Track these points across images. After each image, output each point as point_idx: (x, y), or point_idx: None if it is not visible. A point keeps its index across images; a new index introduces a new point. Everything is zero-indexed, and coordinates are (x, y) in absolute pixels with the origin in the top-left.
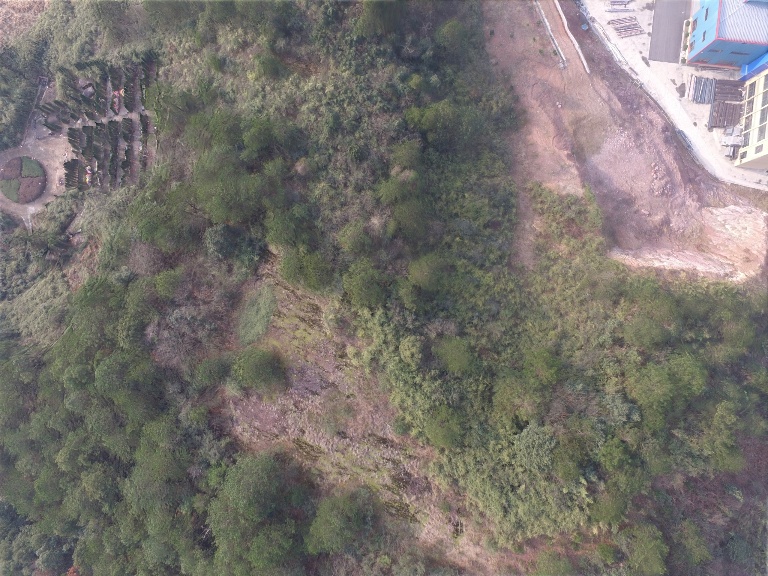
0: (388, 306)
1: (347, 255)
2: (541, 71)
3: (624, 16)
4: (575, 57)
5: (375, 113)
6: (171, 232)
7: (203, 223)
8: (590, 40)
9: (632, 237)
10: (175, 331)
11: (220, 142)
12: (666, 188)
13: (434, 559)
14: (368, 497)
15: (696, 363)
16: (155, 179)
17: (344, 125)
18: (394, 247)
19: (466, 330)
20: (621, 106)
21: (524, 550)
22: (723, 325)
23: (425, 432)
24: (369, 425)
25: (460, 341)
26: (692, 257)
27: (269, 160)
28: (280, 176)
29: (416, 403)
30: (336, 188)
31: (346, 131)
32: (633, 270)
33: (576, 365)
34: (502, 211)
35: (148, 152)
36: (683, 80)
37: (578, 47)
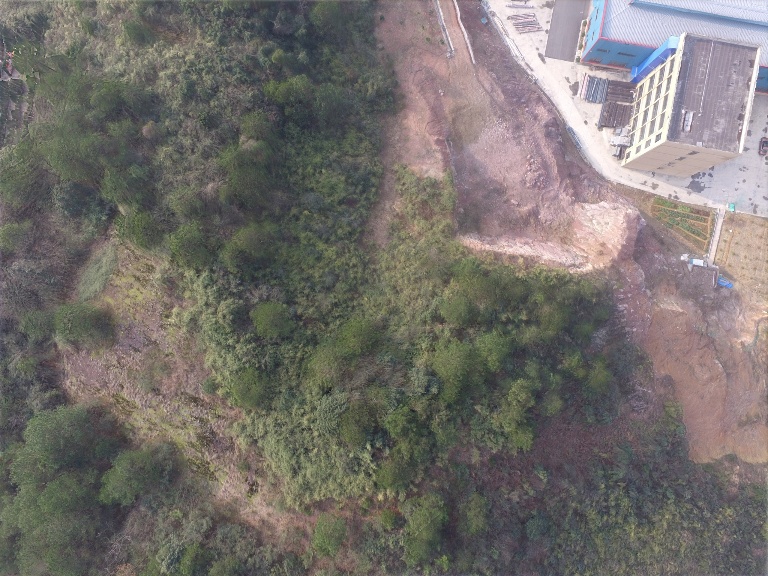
0: (213, 269)
1: (178, 217)
2: (427, 59)
3: (524, 12)
4: (463, 47)
5: (233, 84)
6: (24, 187)
7: (54, 180)
8: (488, 33)
9: (495, 225)
10: (12, 283)
11: (71, 100)
12: (539, 180)
13: (224, 516)
14: (171, 453)
15: (501, 341)
16: (25, 137)
17: (198, 93)
18: (228, 213)
19: (297, 299)
20: (504, 98)
21: (311, 512)
22: (538, 308)
23: (233, 393)
24: (183, 383)
25: (286, 309)
26: (551, 248)
27: (116, 121)
28: (125, 137)
29: (226, 364)
30: (183, 153)
31: (200, 99)
32: (474, 253)
33: (394, 338)
34: (360, 189)
35: (34, 113)
36: (577, 79)
37: (467, 38)
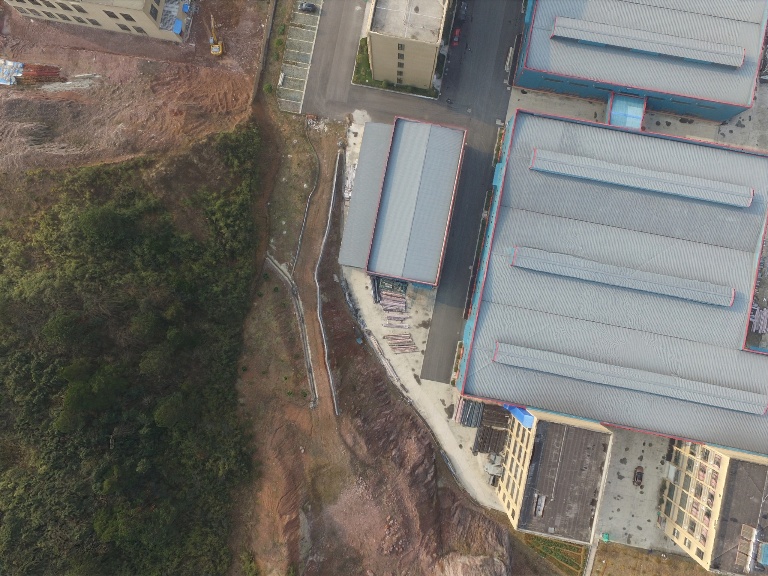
0: None
1: None
2: (290, 411)
3: (400, 332)
4: (327, 396)
5: (62, 518)
6: None
7: None
8: (362, 356)
9: None
10: None
11: None
12: (397, 545)
13: None
14: None
15: None
16: None
17: None
18: None
19: None
20: (366, 451)
21: None
22: None
23: None
24: None
25: None
26: None
27: None
28: None
29: None
30: None
31: (25, 544)
32: None
33: None
34: None
35: None
36: (452, 401)
37: (332, 385)
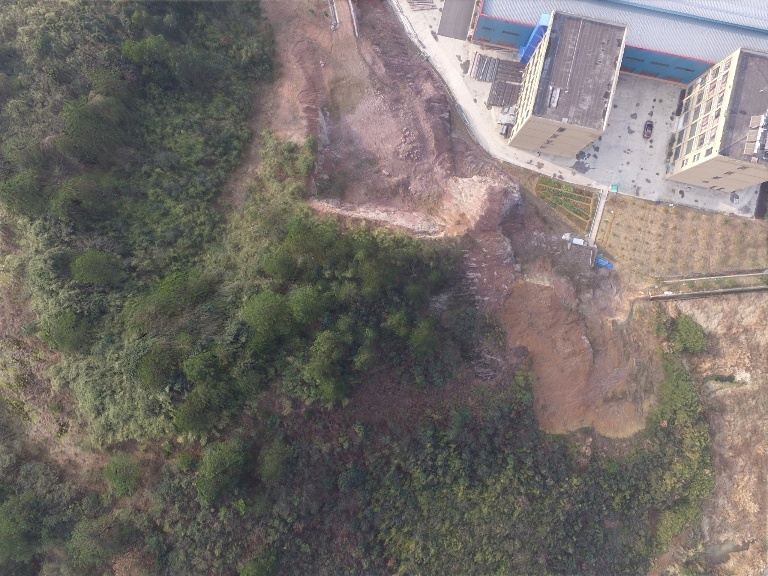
0: (46, 217)
1: (14, 165)
2: (311, 30)
3: None
4: (348, 20)
5: (91, 41)
6: None
7: None
8: (382, 10)
9: (361, 193)
10: None
11: None
12: (413, 153)
13: (31, 454)
14: None
15: (315, 295)
16: None
17: (53, 48)
18: (67, 164)
19: (134, 252)
20: (385, 71)
21: (113, 452)
22: (359, 265)
23: (52, 336)
24: (8, 327)
25: (120, 260)
26: (412, 217)
27: None
28: None
29: (47, 308)
30: (32, 106)
31: (55, 54)
32: (320, 215)
33: (221, 291)
34: (220, 151)
35: None
36: (468, 57)
37: (352, 11)
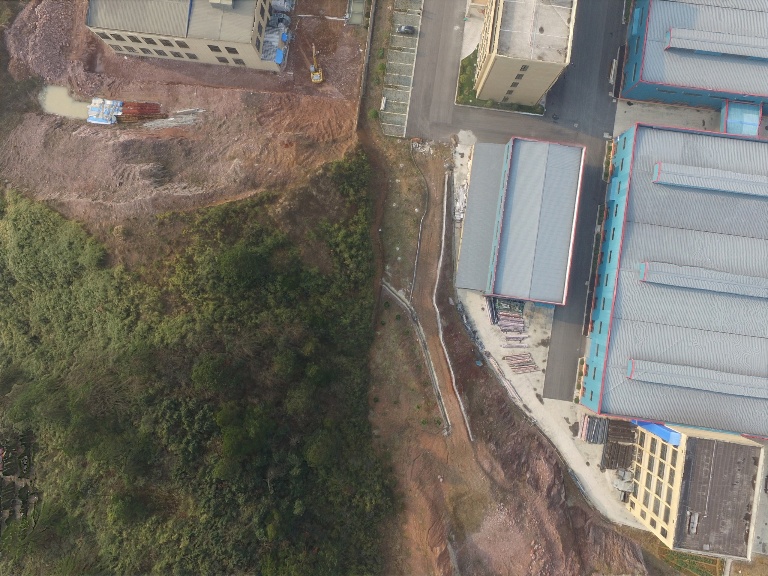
0: None
1: None
2: (424, 440)
3: (519, 352)
4: (460, 422)
5: (230, 567)
6: None
7: None
8: (484, 378)
9: None
10: None
11: None
12: (544, 570)
13: None
14: None
15: None
16: None
17: None
18: None
19: None
20: (504, 476)
21: None
22: None
23: None
24: None
25: None
26: None
27: None
28: None
29: None
30: None
31: None
32: None
33: None
34: None
35: (28, 522)
36: (577, 419)
37: (463, 411)
